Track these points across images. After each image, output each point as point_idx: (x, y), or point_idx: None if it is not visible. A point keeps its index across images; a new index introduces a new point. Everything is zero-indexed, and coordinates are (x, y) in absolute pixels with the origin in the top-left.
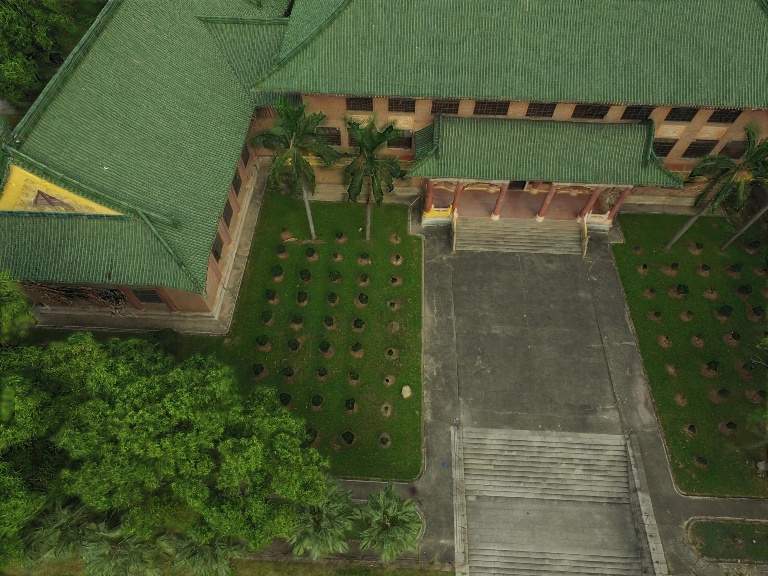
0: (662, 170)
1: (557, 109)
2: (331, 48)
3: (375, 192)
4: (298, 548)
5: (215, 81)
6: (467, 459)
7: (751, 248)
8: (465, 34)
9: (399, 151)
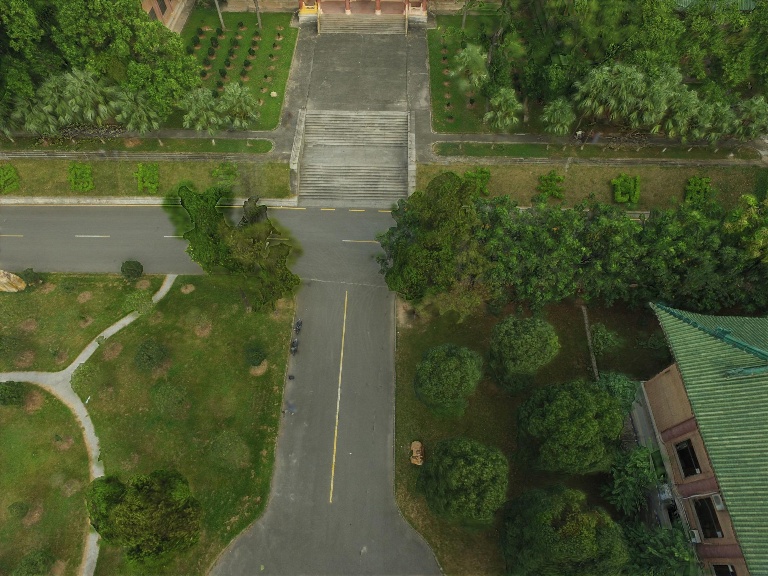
0: None
1: None
2: None
3: None
4: (186, 116)
5: None
6: (308, 126)
7: (520, 29)
8: None
9: None
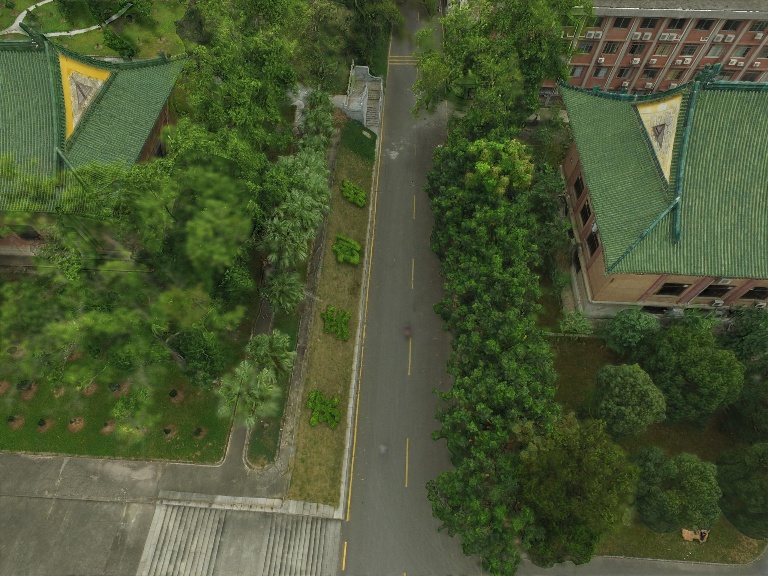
0: None
1: None
2: None
3: None
4: None
5: None
6: None
7: (15, 295)
8: None
9: None
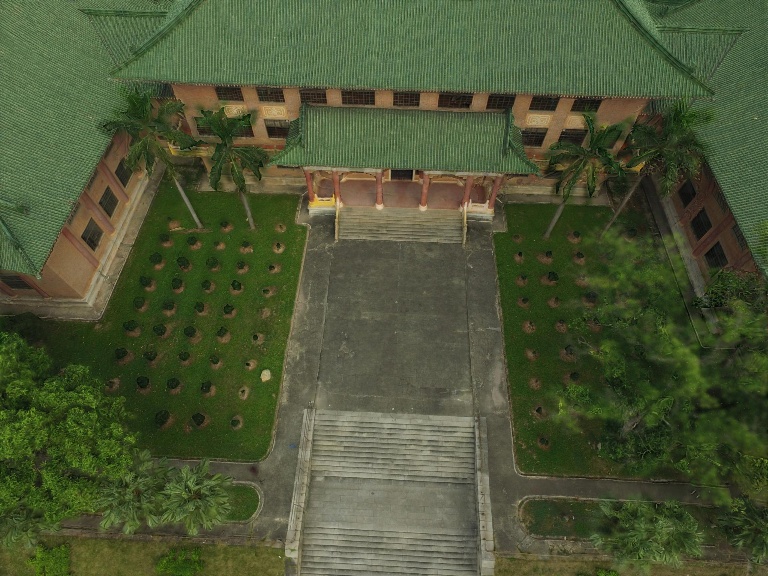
0: (521, 158)
1: (422, 99)
2: (191, 38)
3: (235, 179)
4: (105, 521)
5: (92, 72)
6: (318, 441)
7: (630, 237)
8: (322, 24)
9: (281, 141)
